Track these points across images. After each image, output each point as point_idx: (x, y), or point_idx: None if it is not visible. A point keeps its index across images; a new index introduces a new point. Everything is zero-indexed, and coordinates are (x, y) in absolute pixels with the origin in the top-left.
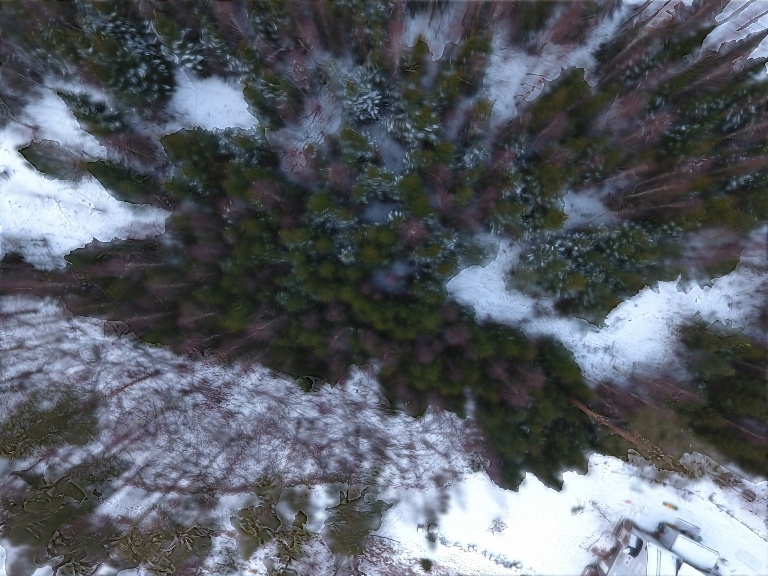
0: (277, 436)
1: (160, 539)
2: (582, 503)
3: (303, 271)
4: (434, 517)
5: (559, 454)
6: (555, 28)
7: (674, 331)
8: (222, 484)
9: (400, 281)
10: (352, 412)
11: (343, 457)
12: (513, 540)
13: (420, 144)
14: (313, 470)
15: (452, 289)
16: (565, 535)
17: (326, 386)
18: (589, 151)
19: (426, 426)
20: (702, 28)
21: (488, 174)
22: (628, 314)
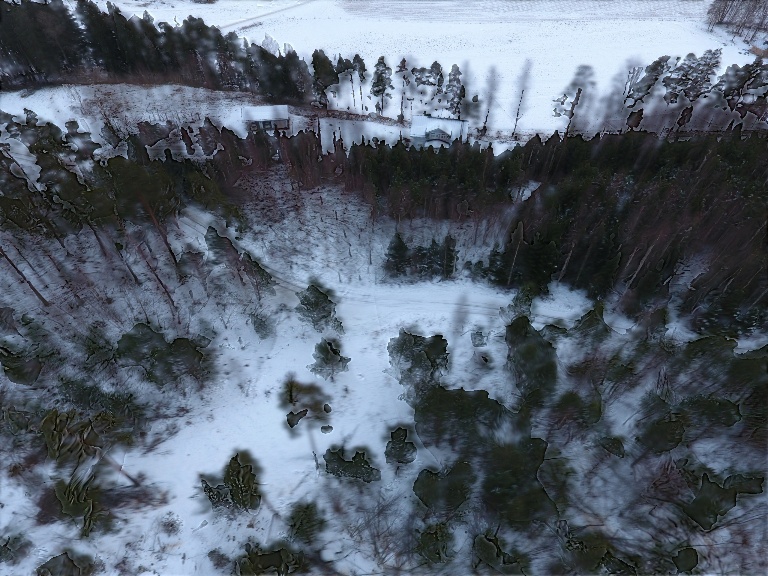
0: None
1: (696, 82)
2: None
3: None
4: None
5: None
6: None
7: None
8: None
9: None
10: None
11: None
12: None
13: None
14: None
15: None
16: None
17: None
18: None
19: None
20: None
21: None
22: None
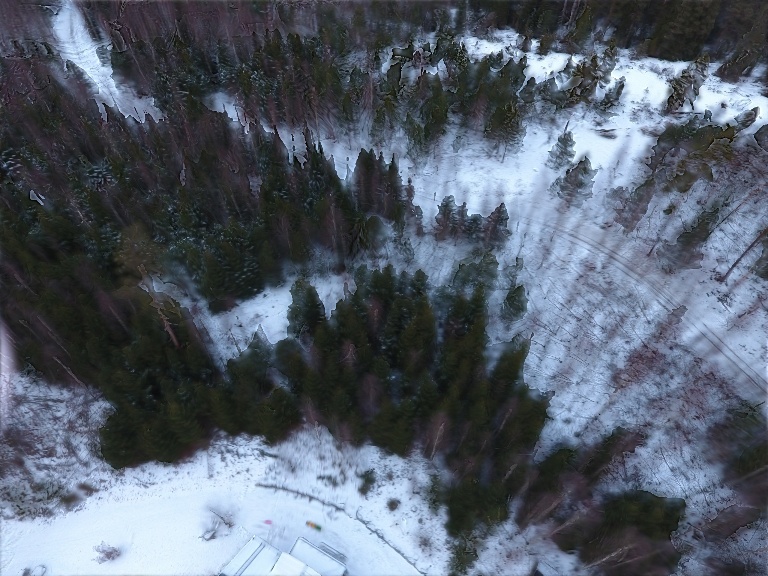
0: None
1: None
2: (217, 525)
3: None
4: (47, 557)
5: None
6: (236, 164)
7: None
8: None
9: None
10: (10, 411)
11: None
12: None
13: None
14: None
15: None
16: (189, 573)
17: None
18: (218, 191)
19: (73, 420)
20: None
21: None
22: (266, 312)
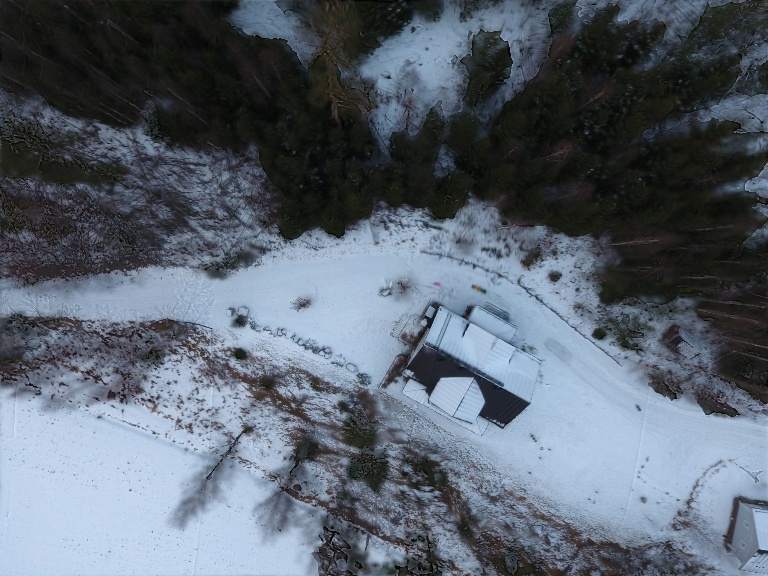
0: (78, 200)
1: None
2: (391, 284)
3: None
4: (244, 300)
5: (334, 189)
6: None
7: (466, 78)
8: (31, 262)
9: None
10: (150, 171)
11: (150, 231)
12: (322, 324)
13: None
14: (122, 247)
15: (239, 25)
16: (374, 319)
17: (118, 136)
18: None
19: (223, 186)
20: None
21: None
22: (419, 58)
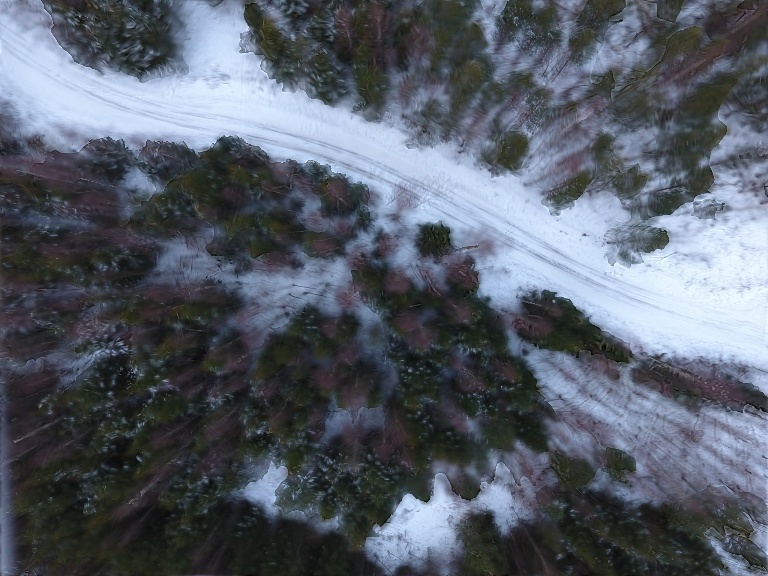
0: None
1: None
2: None
3: (37, 535)
4: None
5: None
6: None
7: None
8: None
9: (166, 508)
10: None
11: None
12: None
13: (159, 391)
14: None
15: None
16: None
17: None
18: None
19: None
20: (399, 295)
21: None
22: (415, 506)
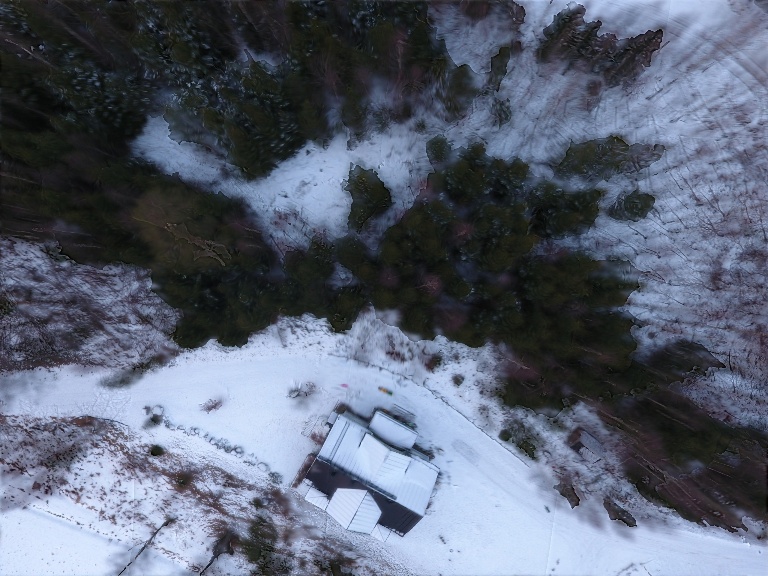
0: None
1: None
2: (299, 386)
3: None
4: (160, 399)
5: (227, 308)
6: None
7: None
8: None
9: None
10: (64, 280)
11: (68, 333)
12: (234, 424)
13: None
14: (43, 347)
15: (143, 149)
16: (284, 419)
17: (33, 249)
18: None
19: (133, 295)
20: None
21: (131, 13)
22: (313, 178)
